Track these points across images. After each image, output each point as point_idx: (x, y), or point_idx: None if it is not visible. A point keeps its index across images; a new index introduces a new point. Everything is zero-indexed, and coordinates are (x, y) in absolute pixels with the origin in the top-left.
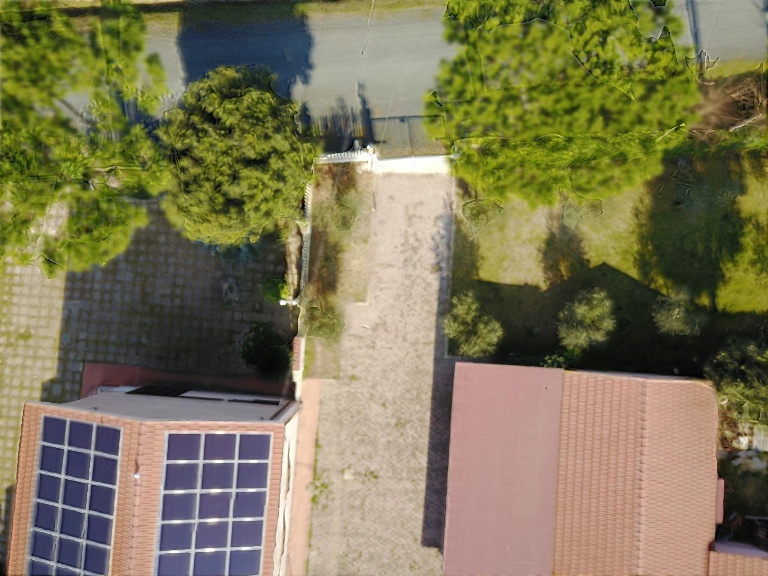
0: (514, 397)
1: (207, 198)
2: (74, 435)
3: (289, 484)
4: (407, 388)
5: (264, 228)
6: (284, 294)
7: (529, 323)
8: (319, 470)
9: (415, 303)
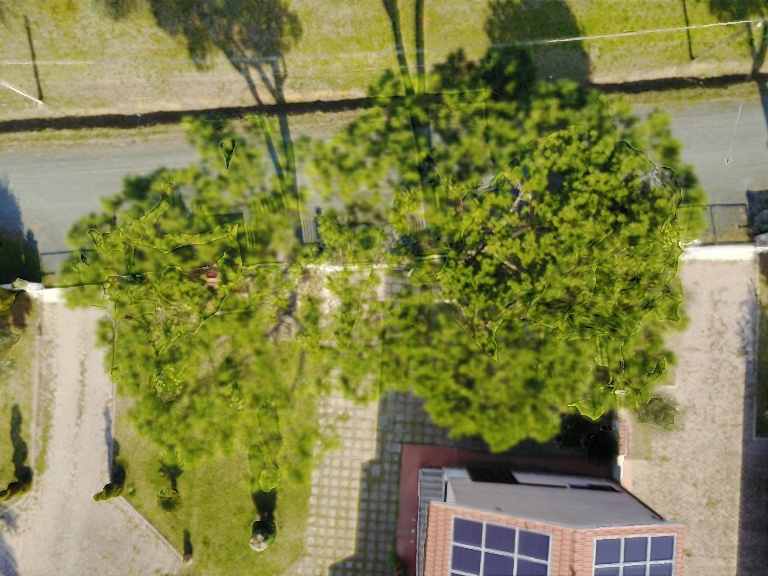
0: None
1: (613, 309)
2: (492, 538)
3: None
4: (717, 469)
5: None
6: (610, 381)
7: None
8: None
9: (723, 386)
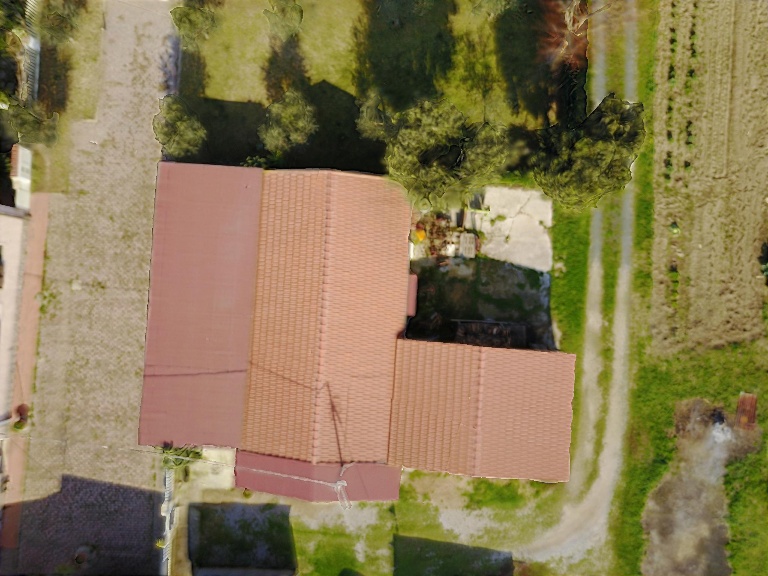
0: (215, 195)
1: None
2: None
3: (2, 283)
4: (134, 202)
5: None
6: None
7: (252, 139)
8: (47, 281)
9: (143, 120)
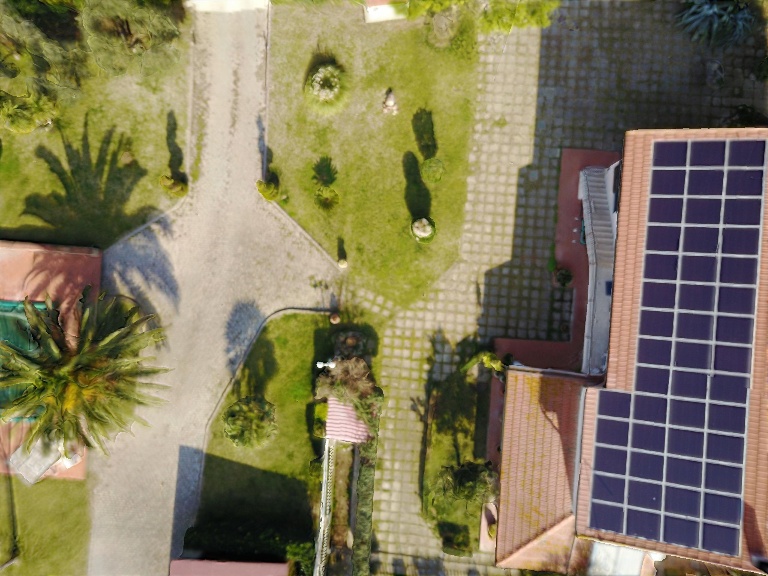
0: None
1: None
2: (698, 155)
3: None
4: None
5: (753, 8)
6: None
7: None
8: None
9: None
